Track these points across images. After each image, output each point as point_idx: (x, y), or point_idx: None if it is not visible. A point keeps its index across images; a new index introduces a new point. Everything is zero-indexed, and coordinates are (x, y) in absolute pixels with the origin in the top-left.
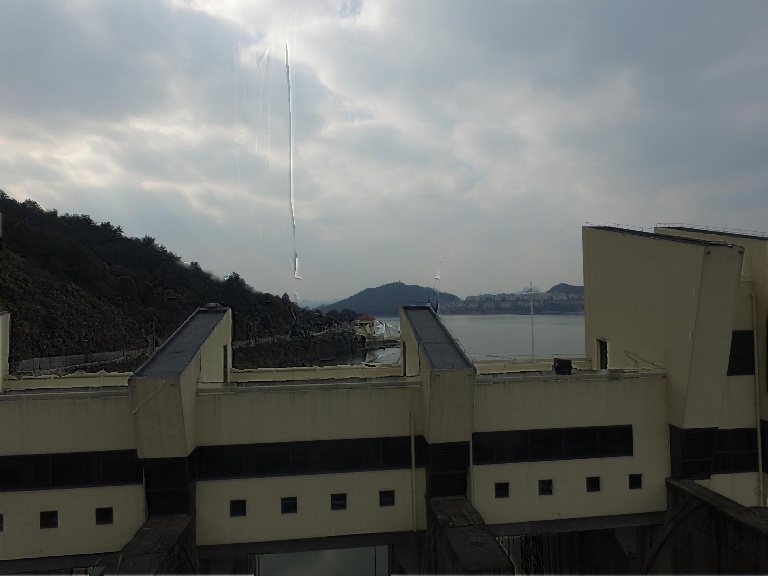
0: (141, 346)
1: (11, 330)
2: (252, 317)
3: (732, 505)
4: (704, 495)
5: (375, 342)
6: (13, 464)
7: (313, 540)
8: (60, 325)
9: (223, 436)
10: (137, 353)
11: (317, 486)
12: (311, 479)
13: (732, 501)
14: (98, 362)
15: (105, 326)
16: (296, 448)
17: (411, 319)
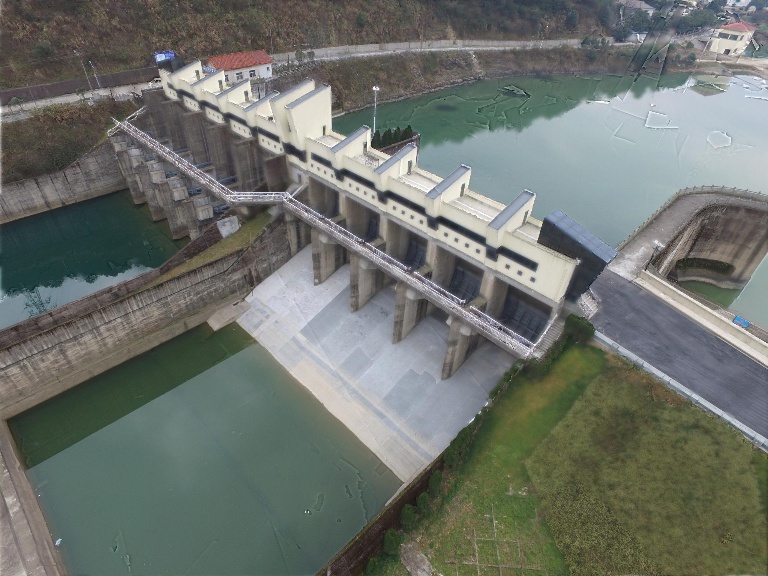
0: (431, 38)
1: (337, 27)
2: (554, 16)
3: (275, 156)
4: (278, 154)
5: (716, 64)
6: (214, 106)
7: (244, 137)
8: (367, 23)
9: (231, 112)
10: (425, 44)
11: (242, 127)
12: (241, 125)
13: (278, 156)
14: (374, 53)
15: (404, 22)
16: (239, 118)
17: (268, 96)
